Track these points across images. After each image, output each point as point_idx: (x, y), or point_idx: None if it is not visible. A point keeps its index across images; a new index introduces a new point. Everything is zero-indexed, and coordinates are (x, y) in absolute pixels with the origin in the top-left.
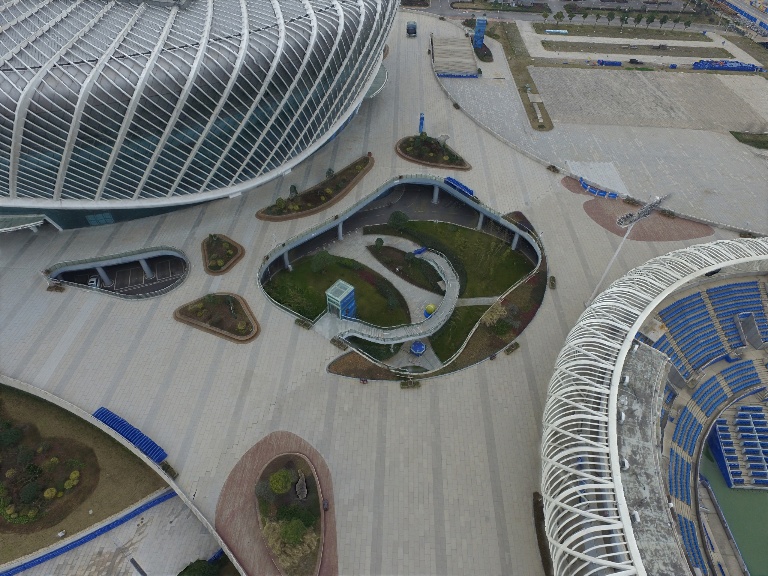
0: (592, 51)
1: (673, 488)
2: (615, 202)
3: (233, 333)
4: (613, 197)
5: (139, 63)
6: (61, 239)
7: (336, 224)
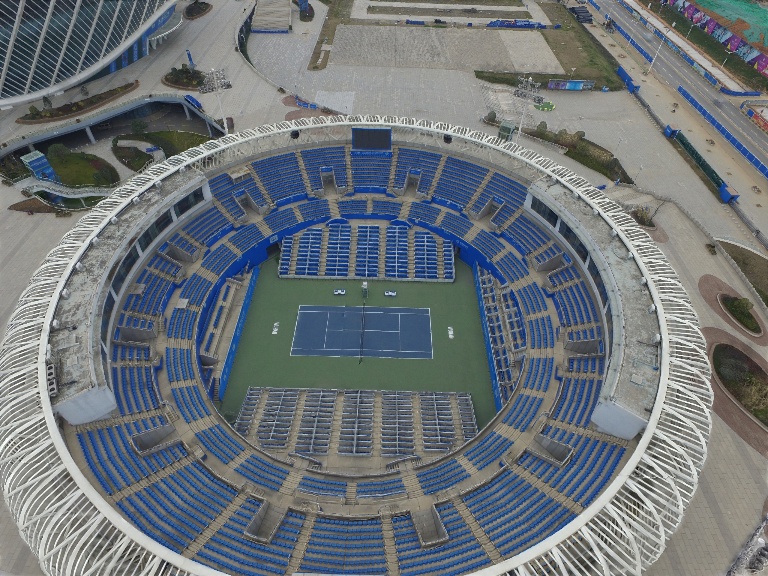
0: (408, 14)
1: (207, 264)
2: (314, 111)
3: None
4: (314, 108)
5: None
6: None
7: (81, 127)
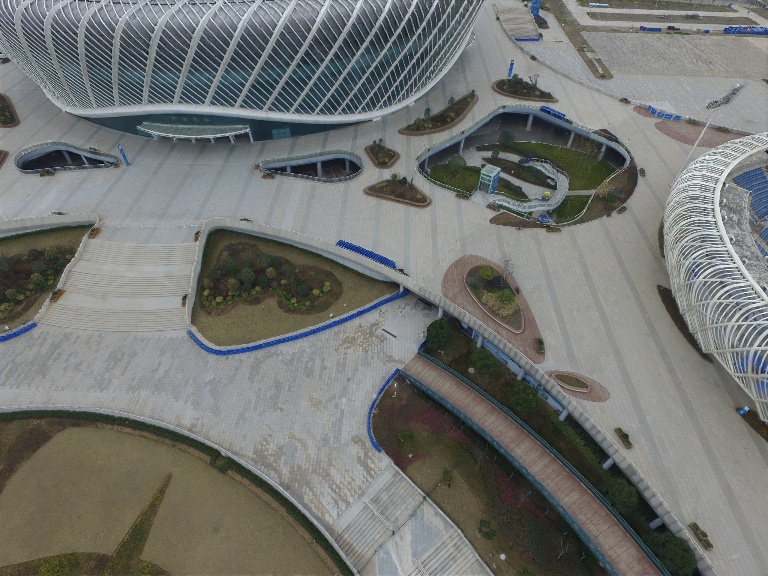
0: (633, 20)
1: None
2: (679, 123)
3: (414, 201)
4: (677, 119)
5: None
6: (255, 147)
7: (461, 139)
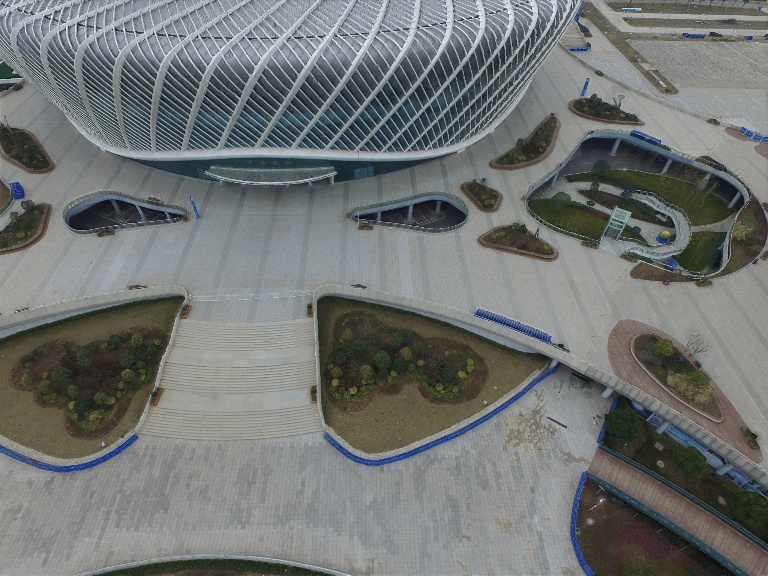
0: (672, 26)
1: None
2: None
3: (540, 253)
4: None
5: (476, 25)
6: (338, 190)
7: (558, 171)
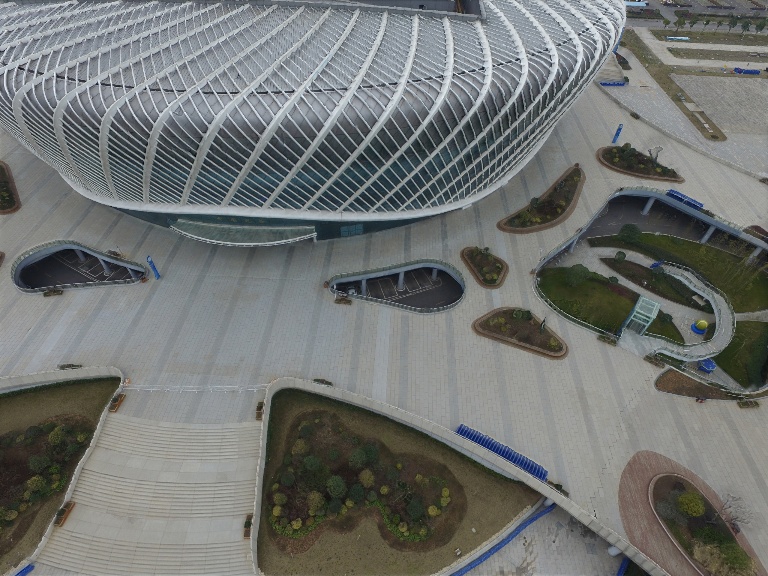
0: (722, 59)
1: None
2: None
3: (545, 349)
4: None
5: (480, 79)
6: (319, 250)
7: (577, 237)
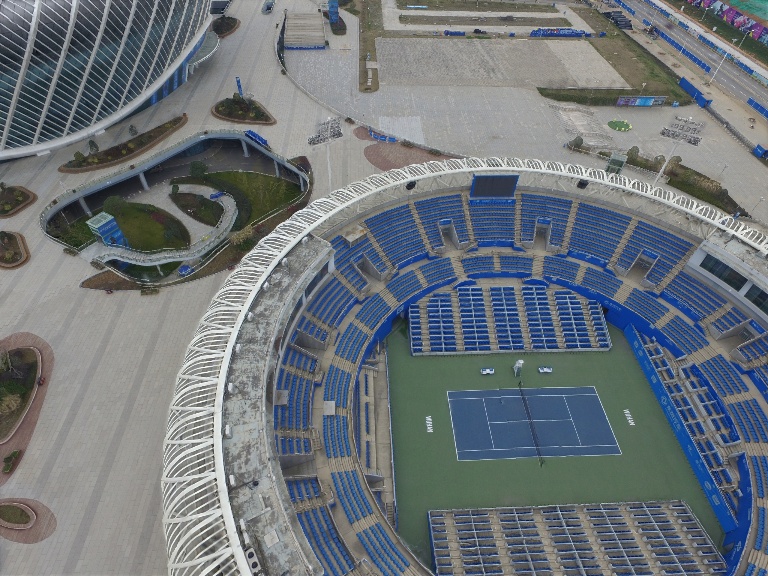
0: (444, 23)
1: (341, 350)
2: (394, 145)
3: (2, 262)
4: (393, 141)
5: None
6: None
7: (134, 174)
